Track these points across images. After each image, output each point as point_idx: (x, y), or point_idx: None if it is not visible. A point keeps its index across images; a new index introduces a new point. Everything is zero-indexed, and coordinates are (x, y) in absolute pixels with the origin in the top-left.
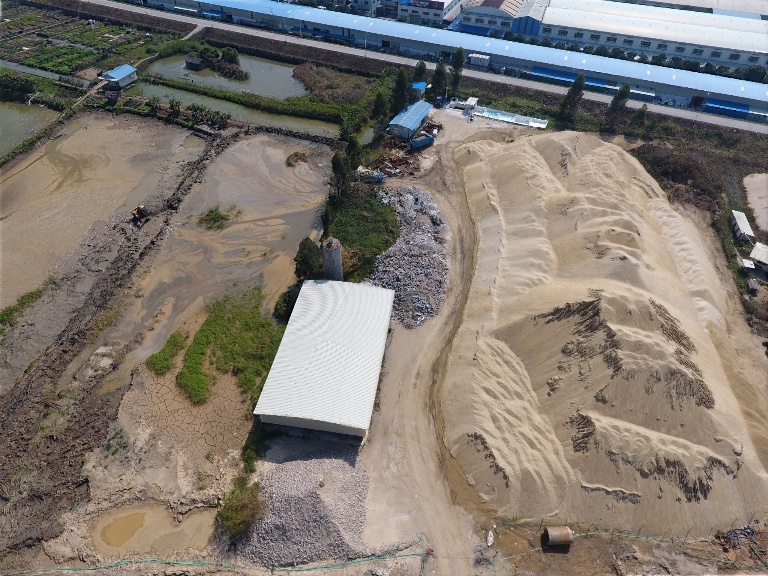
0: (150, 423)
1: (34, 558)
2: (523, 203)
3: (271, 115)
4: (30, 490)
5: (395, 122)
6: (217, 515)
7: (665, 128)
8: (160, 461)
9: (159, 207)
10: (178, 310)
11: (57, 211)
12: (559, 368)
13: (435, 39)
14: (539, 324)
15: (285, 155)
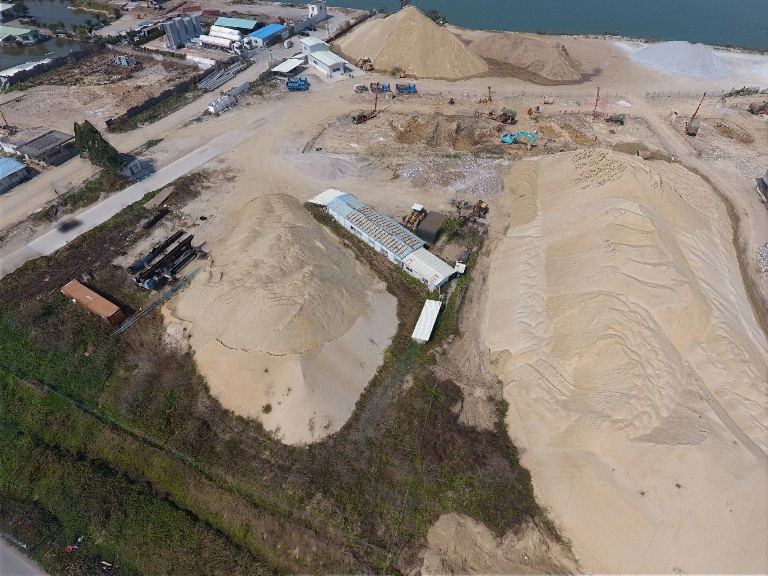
0: None
1: None
2: None
3: None
4: None
5: None
6: None
7: None
8: None
9: None
10: None
11: None
12: None
13: None
14: None
15: None
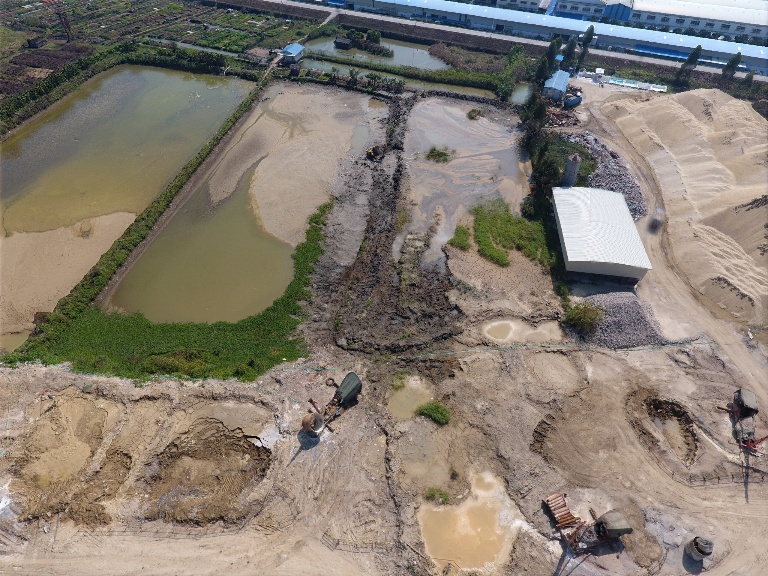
0: (478, 277)
1: (453, 344)
2: (686, 140)
3: (430, 83)
4: (422, 311)
5: (548, 86)
6: (560, 323)
7: (765, 91)
8: (501, 296)
9: (381, 149)
10: (449, 213)
11: (303, 152)
12: (766, 237)
13: (546, 23)
14: (740, 212)
15: (463, 112)
